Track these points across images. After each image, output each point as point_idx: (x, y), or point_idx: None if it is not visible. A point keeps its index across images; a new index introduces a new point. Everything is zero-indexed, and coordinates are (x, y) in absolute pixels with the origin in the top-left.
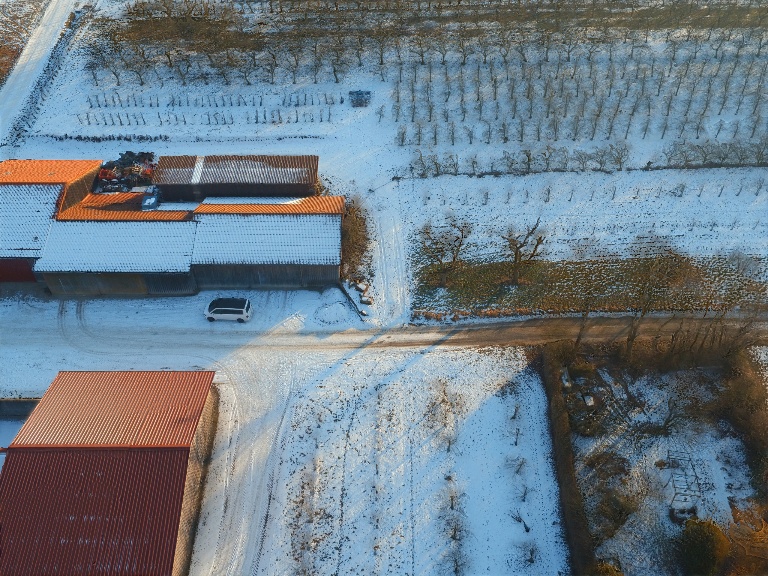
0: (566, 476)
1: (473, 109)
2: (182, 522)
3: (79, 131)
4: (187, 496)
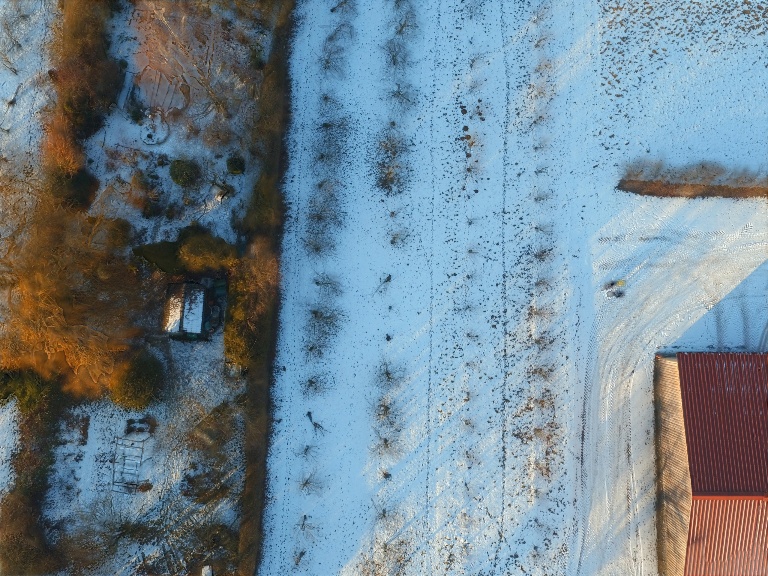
0: (258, 467)
1: None
2: (676, 422)
3: None
4: (677, 452)
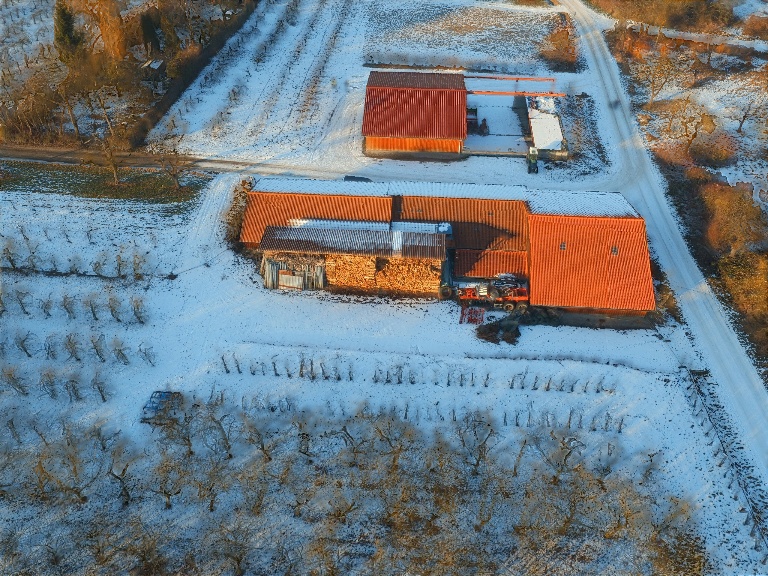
0: None
1: (7, 347)
2: None
3: (603, 374)
4: None
